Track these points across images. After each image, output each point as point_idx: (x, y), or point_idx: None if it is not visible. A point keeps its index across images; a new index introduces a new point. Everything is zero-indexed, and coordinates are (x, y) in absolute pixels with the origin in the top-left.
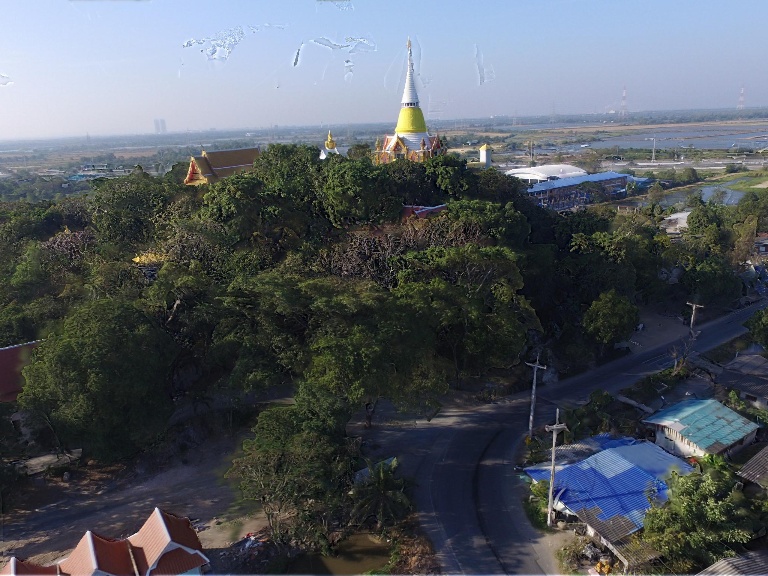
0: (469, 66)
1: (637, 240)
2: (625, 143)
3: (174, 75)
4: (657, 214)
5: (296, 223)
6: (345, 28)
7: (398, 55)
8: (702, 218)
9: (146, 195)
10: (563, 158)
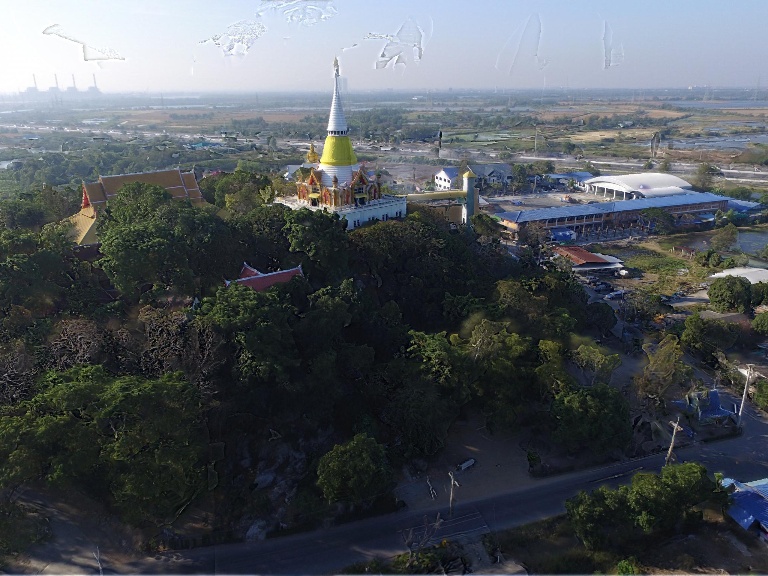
0: (595, 47)
1: (512, 344)
2: None
3: (185, 72)
4: (712, 265)
5: (48, 294)
6: (417, 12)
7: (515, 33)
8: (724, 292)
9: None
10: (670, 166)
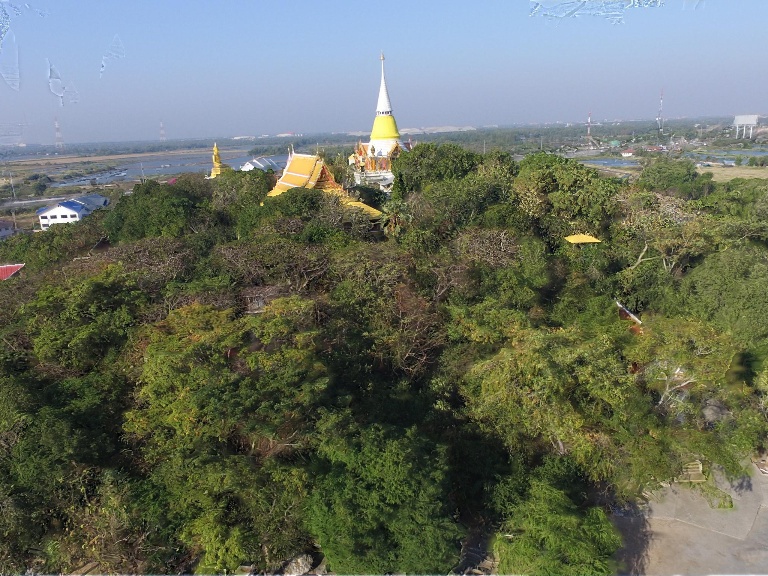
0: (43, 83)
1: None
2: (151, 170)
3: None
4: None
5: None
6: None
7: None
8: None
9: (491, 188)
10: None
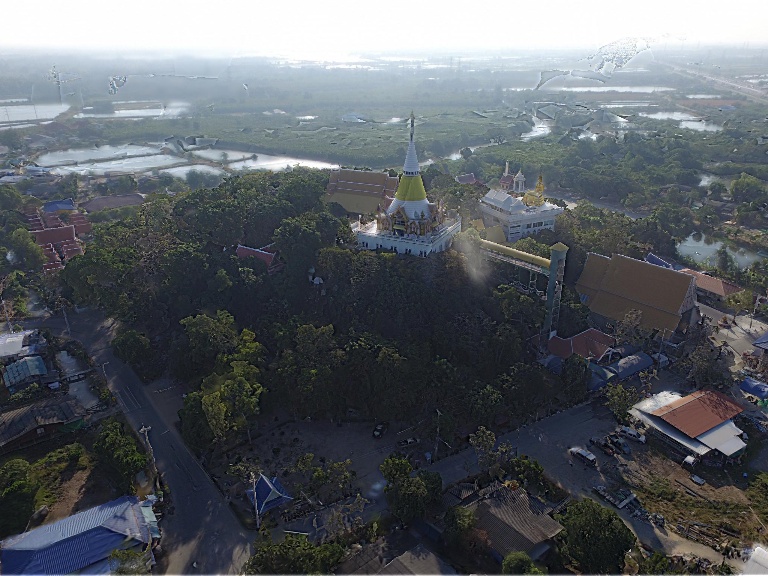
0: None
1: None
2: None
3: (555, 88)
4: None
5: None
6: None
7: None
8: None
9: None
10: None
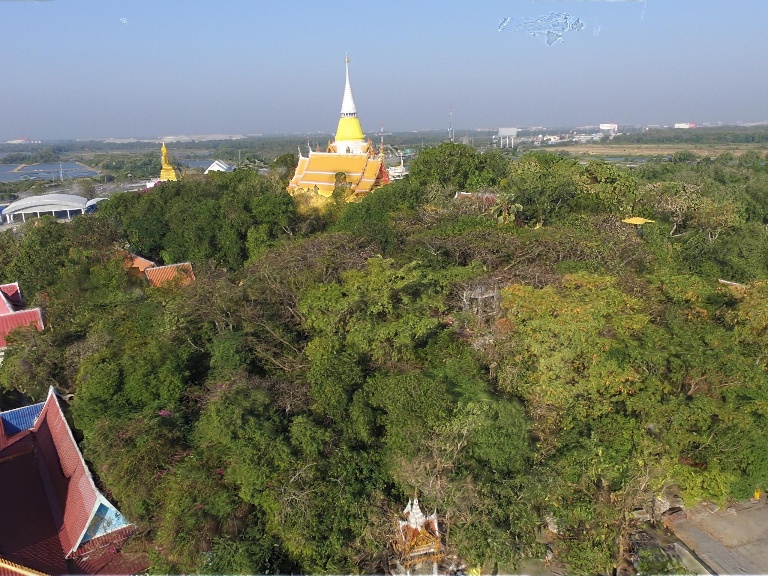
0: None
1: None
2: None
3: None
4: None
5: None
6: None
7: None
8: None
9: None
10: (44, 188)
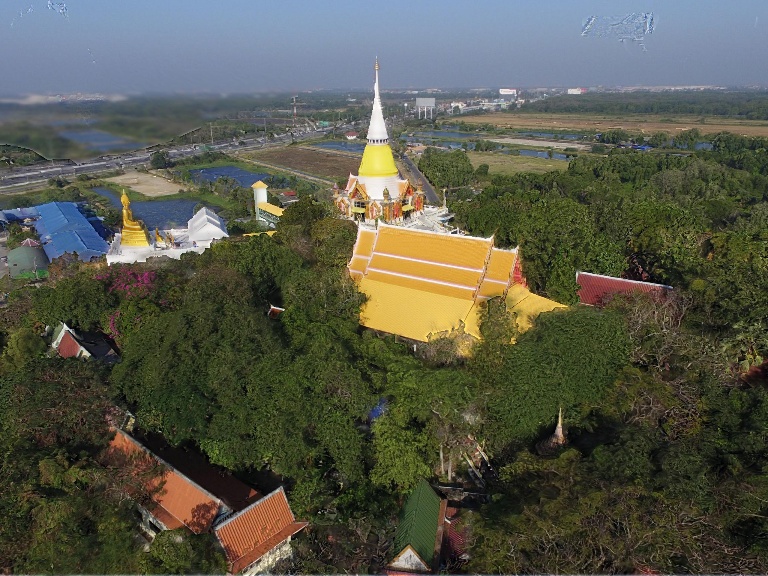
0: None
1: None
2: None
3: None
4: None
5: None
6: None
7: None
8: None
9: None
10: None
